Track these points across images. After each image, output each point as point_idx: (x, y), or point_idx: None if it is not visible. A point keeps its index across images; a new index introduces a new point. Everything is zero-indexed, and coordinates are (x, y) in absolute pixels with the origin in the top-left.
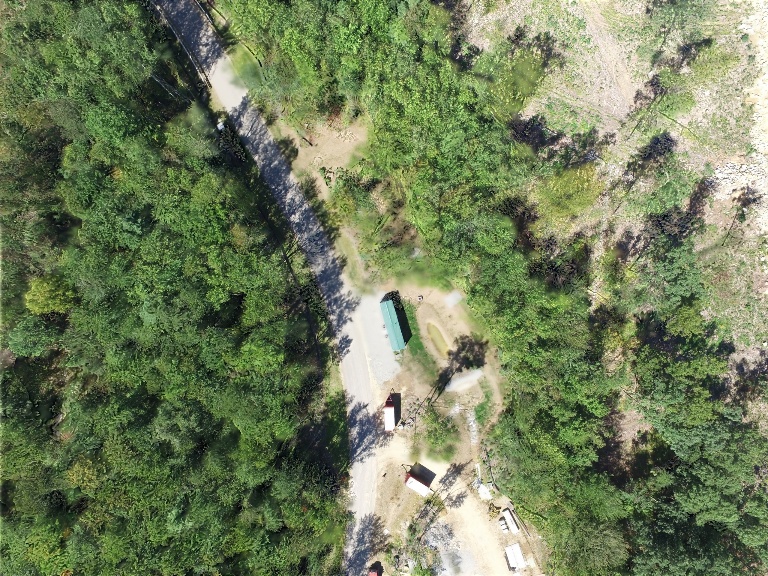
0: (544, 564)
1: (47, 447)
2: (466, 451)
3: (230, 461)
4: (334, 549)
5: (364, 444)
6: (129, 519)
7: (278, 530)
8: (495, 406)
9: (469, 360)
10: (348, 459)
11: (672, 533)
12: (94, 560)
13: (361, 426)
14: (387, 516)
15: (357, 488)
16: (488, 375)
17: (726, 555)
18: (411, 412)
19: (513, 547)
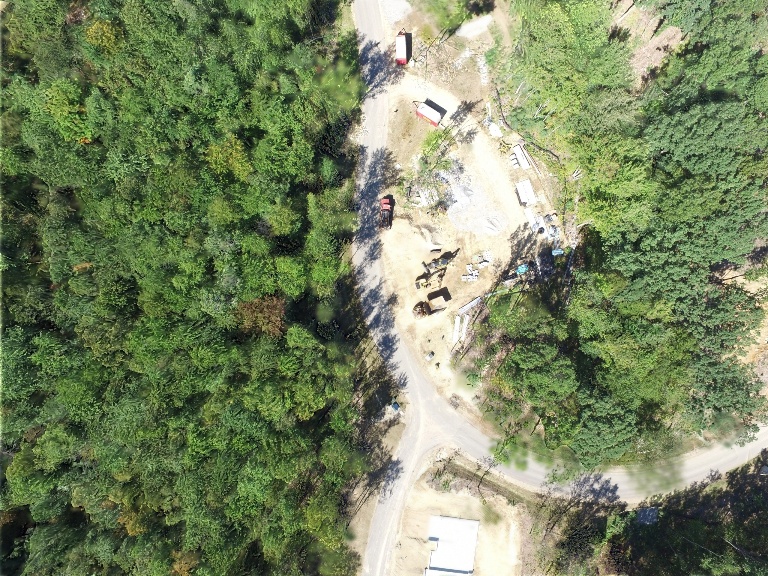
0: (555, 201)
1: (67, 10)
2: (477, 90)
3: (245, 34)
4: (346, 183)
5: (376, 81)
6: (146, 88)
7: (293, 92)
8: (505, 49)
9: (479, 6)
10: (360, 95)
11: (683, 103)
12: (112, 121)
13: (373, 63)
14: (399, 152)
15: (369, 123)
16: (498, 19)
17: (737, 100)
18: (422, 50)
19: (524, 183)
